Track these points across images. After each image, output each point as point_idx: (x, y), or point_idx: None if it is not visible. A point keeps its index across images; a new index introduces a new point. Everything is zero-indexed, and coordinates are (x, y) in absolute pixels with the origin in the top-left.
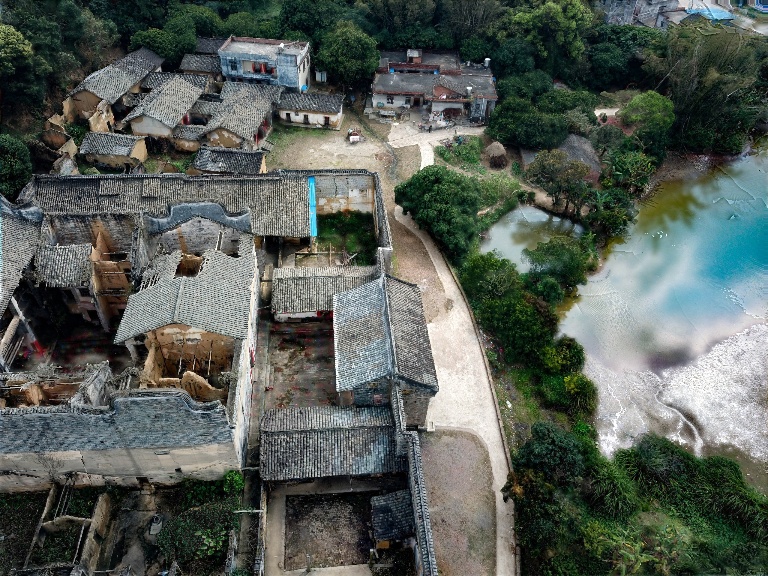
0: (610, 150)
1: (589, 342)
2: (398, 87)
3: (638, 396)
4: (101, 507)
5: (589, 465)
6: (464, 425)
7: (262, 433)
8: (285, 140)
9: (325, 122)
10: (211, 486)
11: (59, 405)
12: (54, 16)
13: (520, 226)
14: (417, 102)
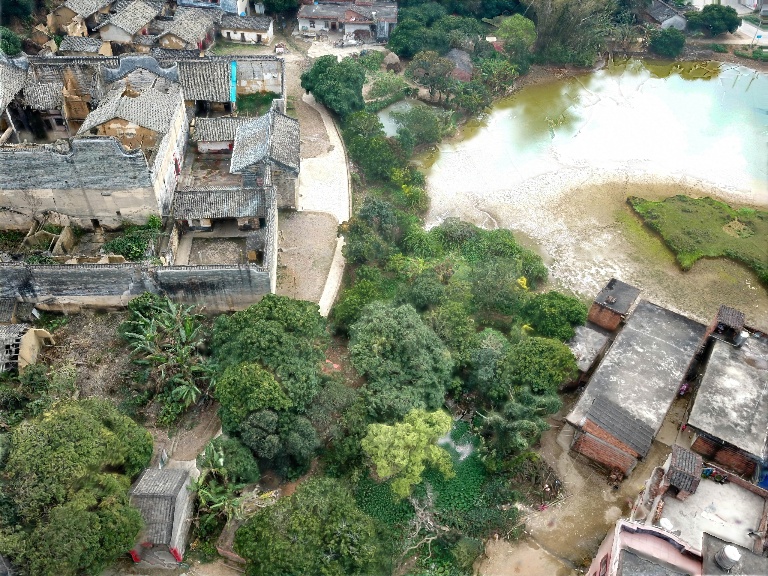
0: (481, 59)
1: (435, 177)
2: (318, 13)
3: (461, 205)
4: (66, 232)
5: (407, 230)
6: (325, 209)
7: (176, 192)
8: (225, 52)
9: (258, 39)
10: (141, 227)
11: (38, 147)
12: None
13: (403, 111)
14: (334, 26)
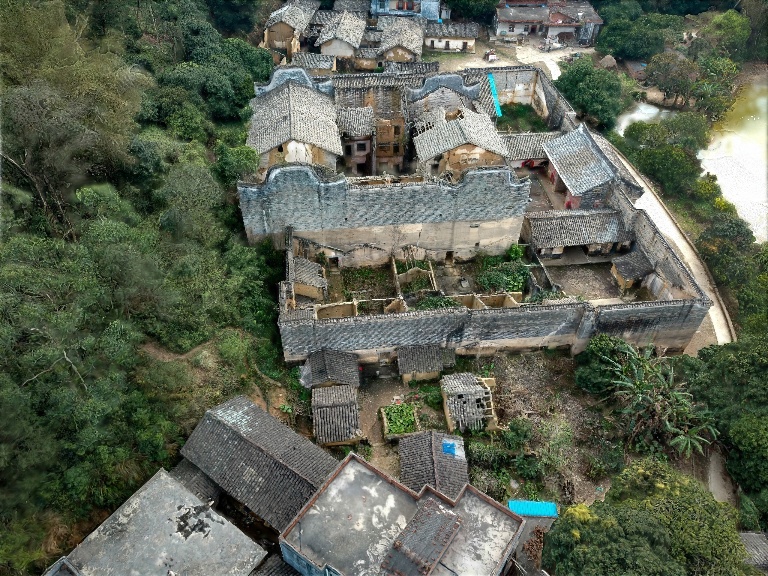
0: (702, 58)
1: None
2: (518, 17)
3: (766, 216)
4: None
5: None
6: None
7: (530, 219)
8: None
9: (463, 47)
10: (497, 257)
11: (426, 181)
12: None
13: (640, 116)
14: (534, 29)
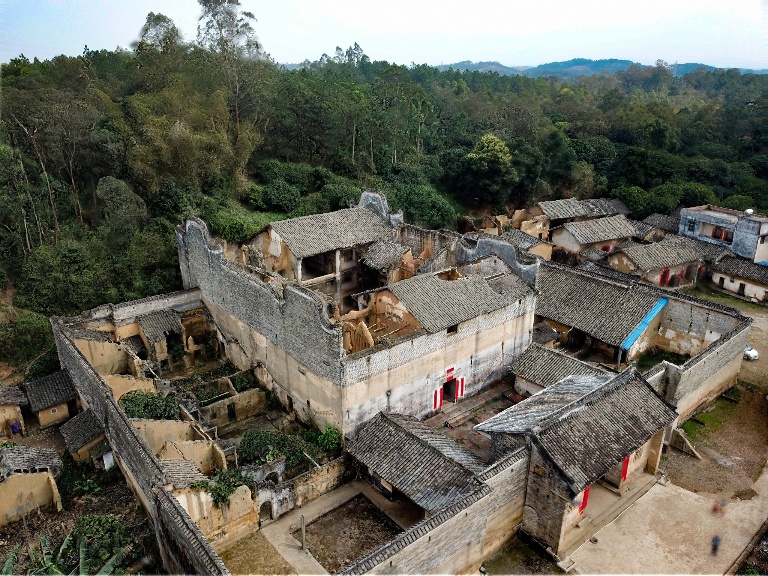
0: None
1: None
2: None
3: None
4: (252, 395)
5: None
6: None
7: (380, 414)
8: None
9: (764, 298)
10: None
11: None
12: (551, 154)
13: None
14: None
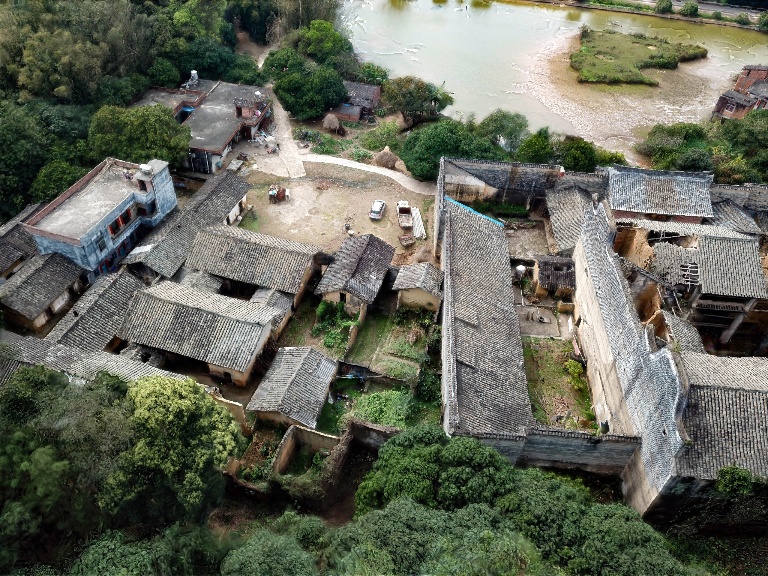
0: None
1: None
2: (215, 136)
3: None
4: None
5: None
6: None
7: None
8: None
9: (239, 209)
10: None
11: None
12: None
13: None
14: None
